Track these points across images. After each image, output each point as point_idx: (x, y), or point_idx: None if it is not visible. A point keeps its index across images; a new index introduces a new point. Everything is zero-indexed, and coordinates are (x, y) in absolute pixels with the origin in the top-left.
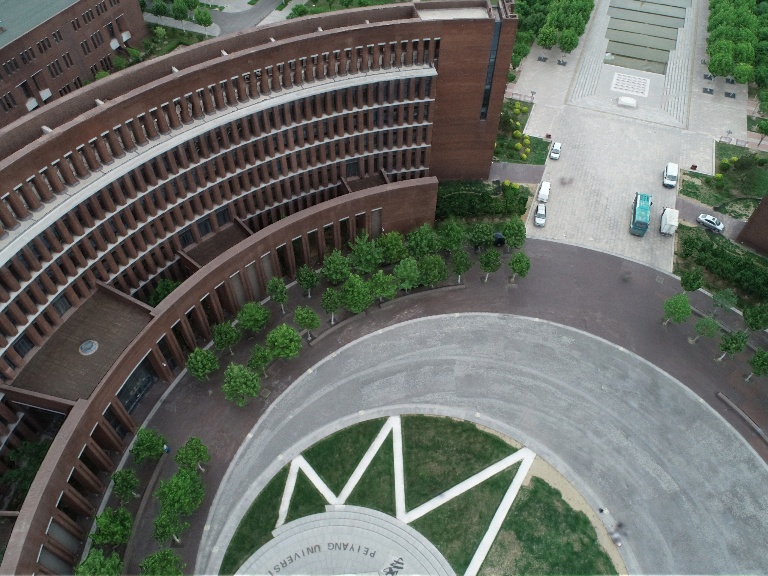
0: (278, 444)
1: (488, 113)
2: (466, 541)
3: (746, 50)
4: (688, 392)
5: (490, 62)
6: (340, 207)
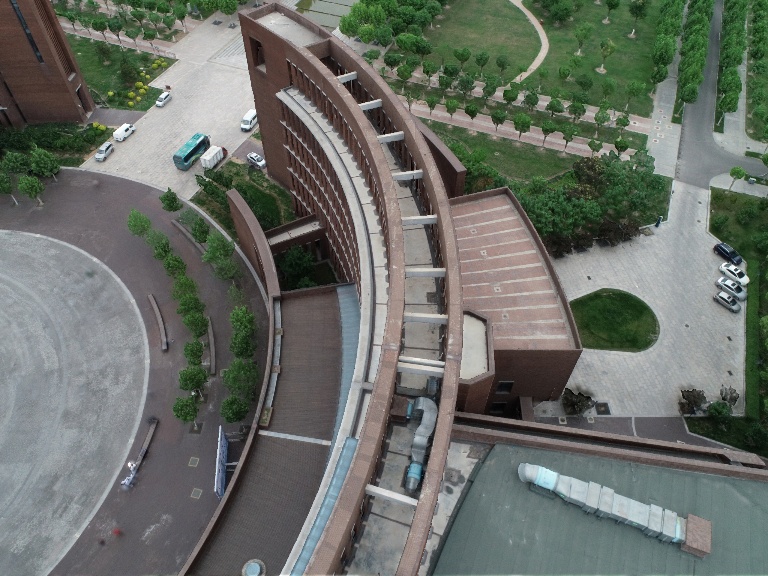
0: None
1: (43, 56)
2: None
3: (373, 12)
4: (126, 294)
5: (16, 7)
6: None
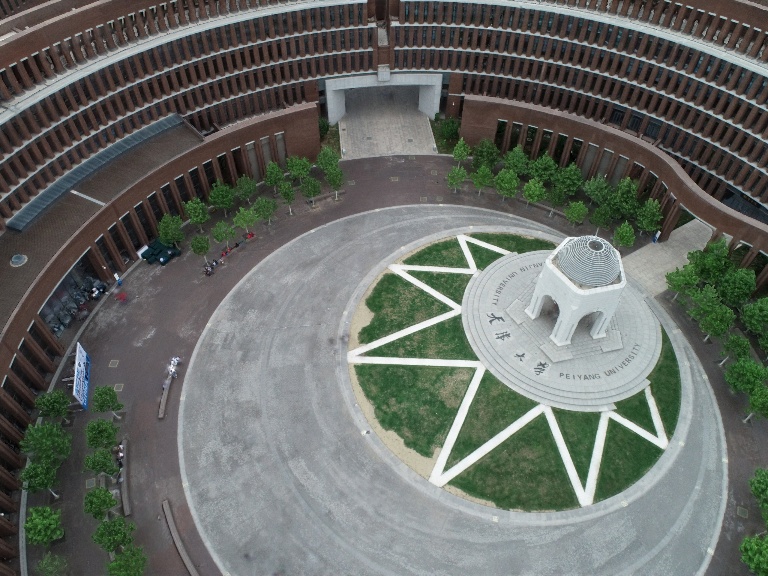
0: (692, 456)
1: None
2: (487, 396)
3: None
4: None
5: None
6: None
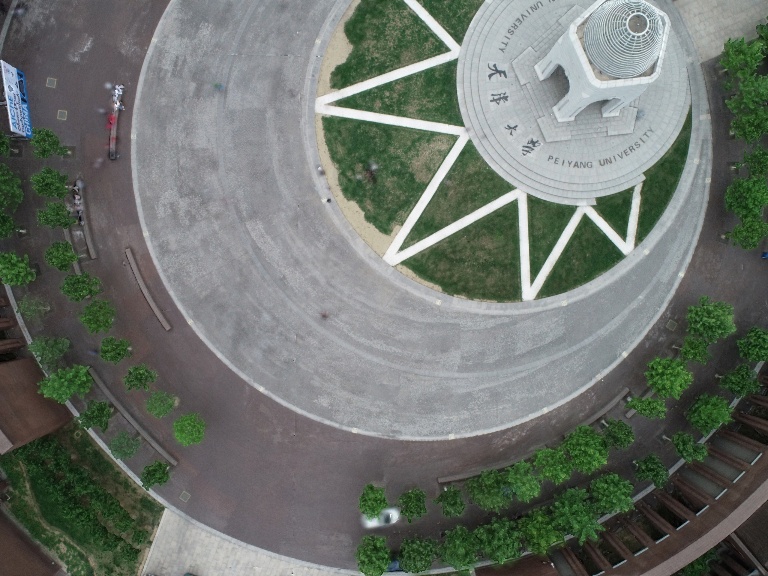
0: (651, 266)
1: None
2: (462, 173)
3: None
4: (202, 332)
5: None
6: (635, 574)
